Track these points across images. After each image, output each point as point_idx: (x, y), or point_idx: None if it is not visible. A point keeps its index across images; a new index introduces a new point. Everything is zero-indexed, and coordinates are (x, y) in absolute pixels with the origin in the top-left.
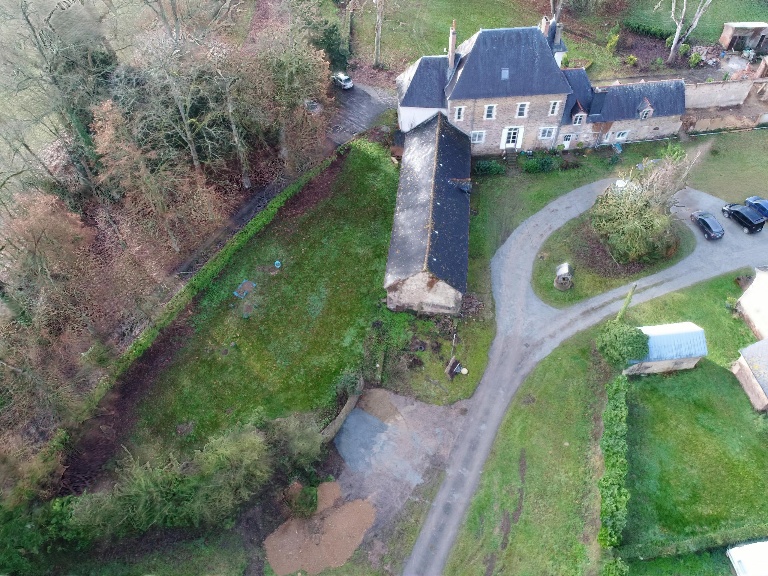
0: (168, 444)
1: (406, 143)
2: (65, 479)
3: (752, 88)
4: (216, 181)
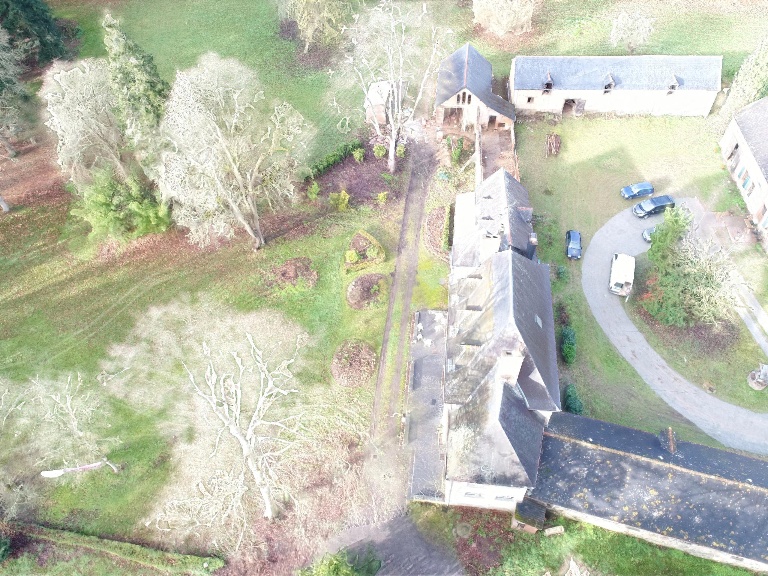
0: None
1: (556, 501)
2: None
3: (455, 131)
4: None
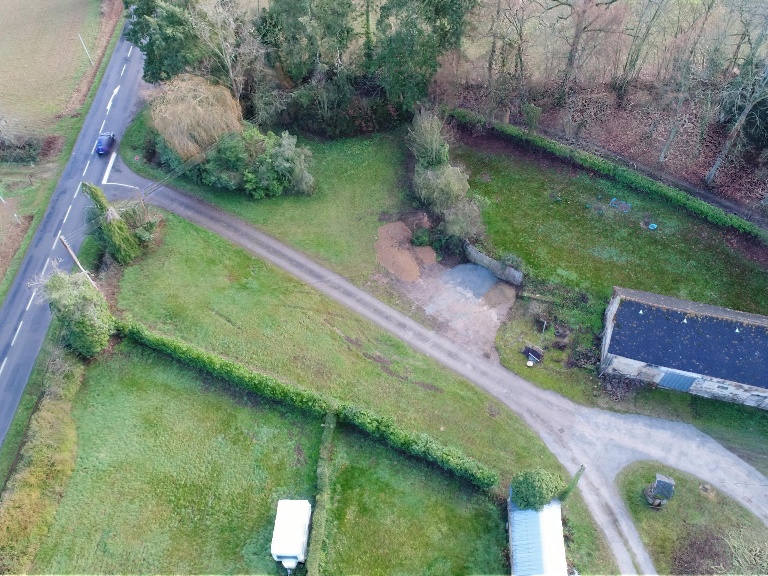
0: (475, 170)
1: None
2: (457, 129)
3: None
4: (767, 182)
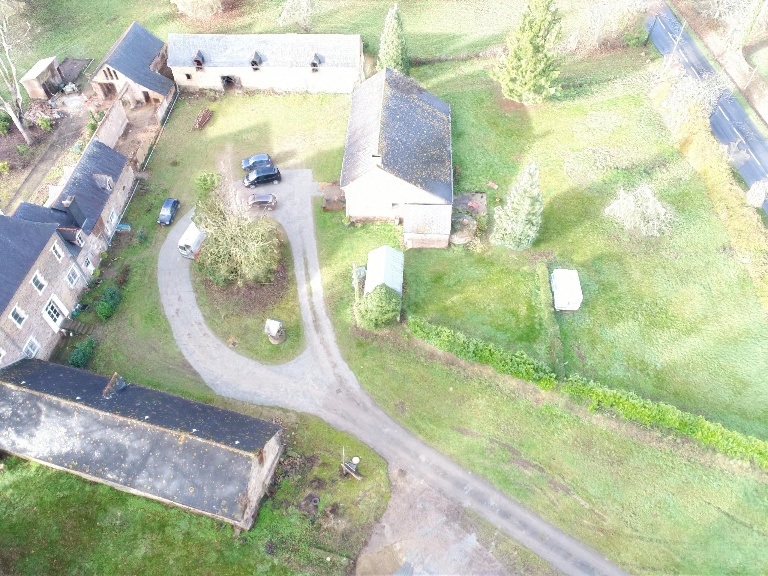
0: None
1: None
2: None
3: None
4: None
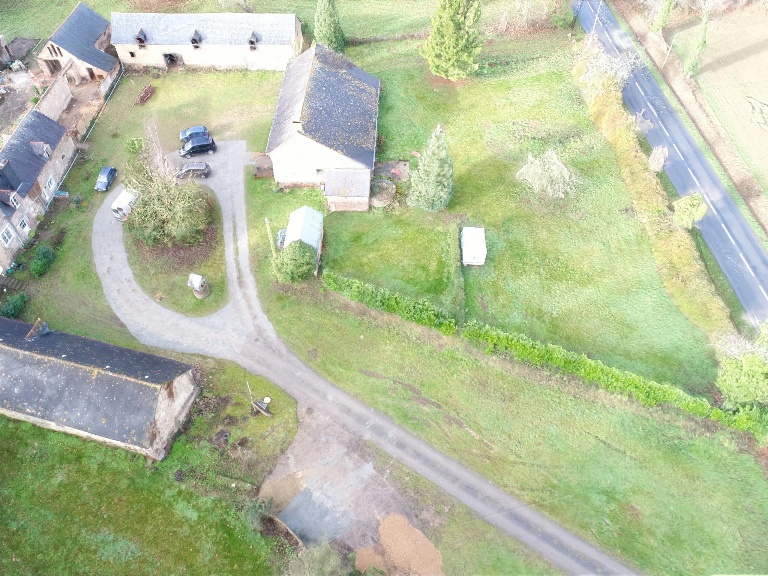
0: None
1: None
2: None
3: None
4: None
